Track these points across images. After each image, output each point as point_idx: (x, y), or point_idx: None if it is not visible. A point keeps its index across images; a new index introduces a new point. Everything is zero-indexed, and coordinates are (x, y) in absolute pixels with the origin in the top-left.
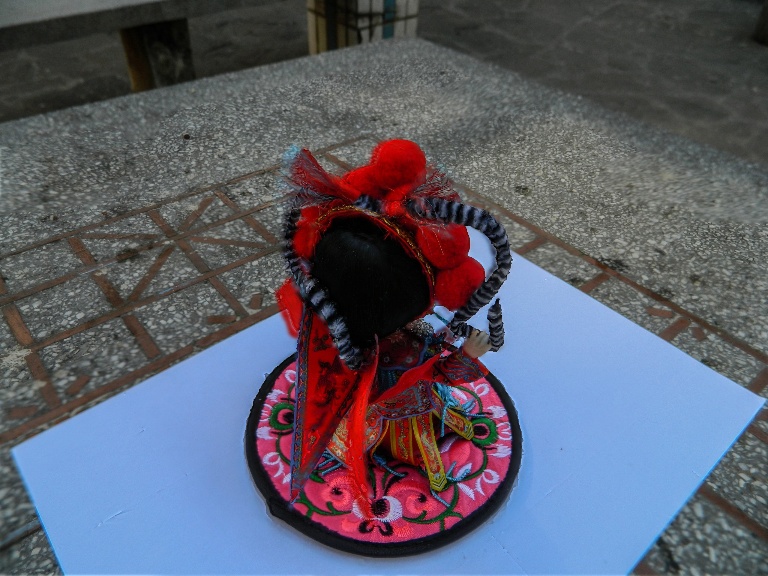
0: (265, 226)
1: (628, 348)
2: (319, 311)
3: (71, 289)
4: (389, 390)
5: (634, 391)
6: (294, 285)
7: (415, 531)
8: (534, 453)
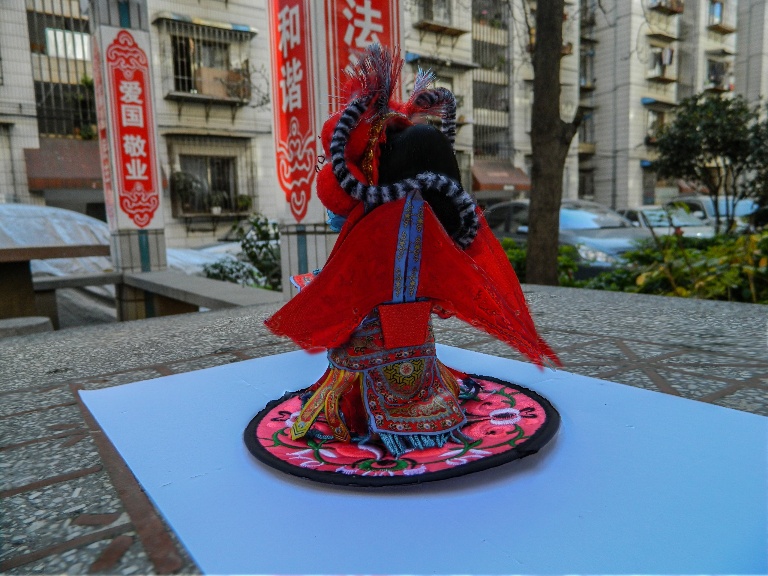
0: None
1: None
2: None
3: None
4: None
5: None
6: (339, 254)
7: None
8: None
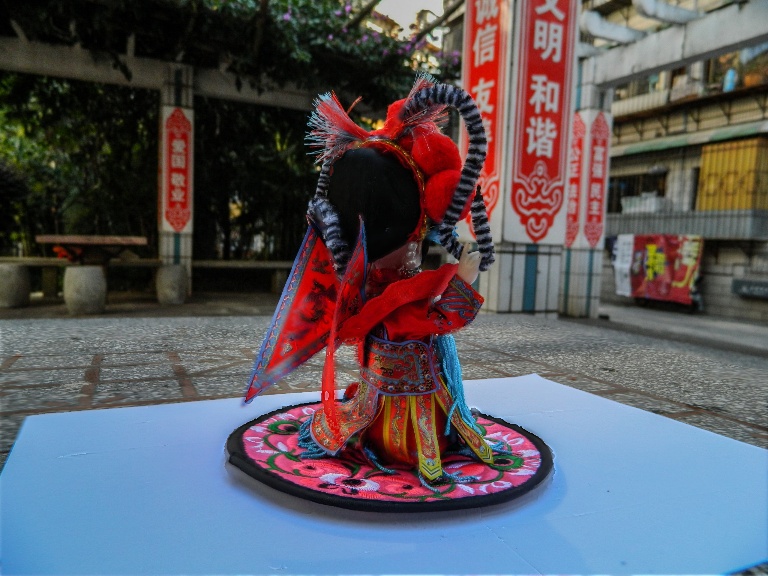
0: (337, 361)
1: (719, 449)
2: (323, 230)
3: (150, 367)
4: (374, 299)
5: (723, 473)
6: None
7: (385, 497)
8: (569, 489)
